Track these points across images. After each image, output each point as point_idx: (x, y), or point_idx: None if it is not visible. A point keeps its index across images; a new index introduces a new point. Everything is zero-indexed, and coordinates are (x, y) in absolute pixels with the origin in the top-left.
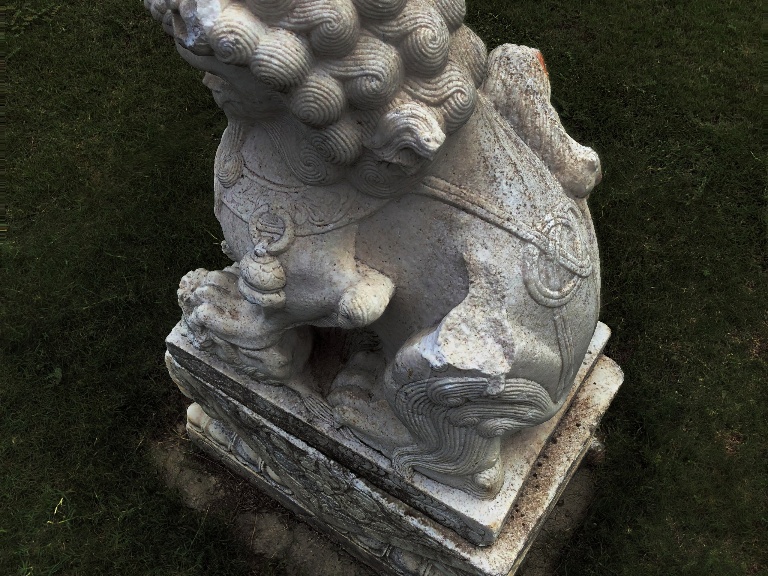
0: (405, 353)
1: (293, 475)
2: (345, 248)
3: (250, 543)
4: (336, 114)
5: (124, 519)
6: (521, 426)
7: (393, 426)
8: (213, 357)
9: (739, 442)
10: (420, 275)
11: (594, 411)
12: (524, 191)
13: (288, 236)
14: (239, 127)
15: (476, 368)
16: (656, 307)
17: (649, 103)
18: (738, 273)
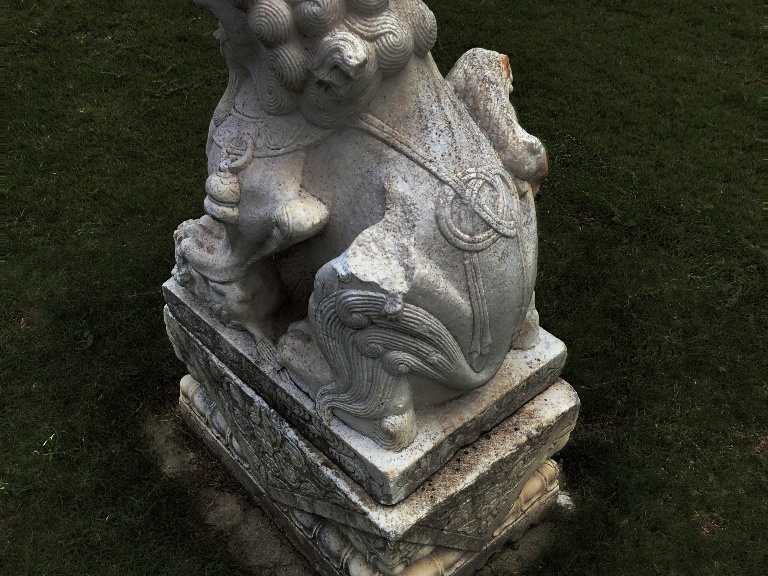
0: (322, 267)
1: (247, 437)
2: (292, 173)
3: (204, 513)
4: (283, 32)
5: (99, 463)
6: (427, 371)
7: (320, 365)
8: (195, 301)
9: (718, 526)
10: (349, 203)
11: (537, 421)
12: (452, 143)
13: (247, 155)
14: (236, 76)
15: (375, 281)
16: (662, 391)
17: (703, 223)
18: (757, 376)
